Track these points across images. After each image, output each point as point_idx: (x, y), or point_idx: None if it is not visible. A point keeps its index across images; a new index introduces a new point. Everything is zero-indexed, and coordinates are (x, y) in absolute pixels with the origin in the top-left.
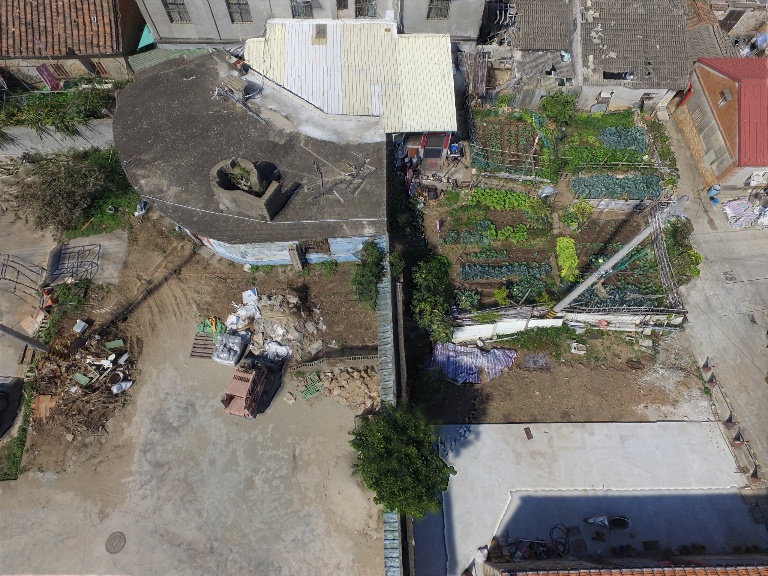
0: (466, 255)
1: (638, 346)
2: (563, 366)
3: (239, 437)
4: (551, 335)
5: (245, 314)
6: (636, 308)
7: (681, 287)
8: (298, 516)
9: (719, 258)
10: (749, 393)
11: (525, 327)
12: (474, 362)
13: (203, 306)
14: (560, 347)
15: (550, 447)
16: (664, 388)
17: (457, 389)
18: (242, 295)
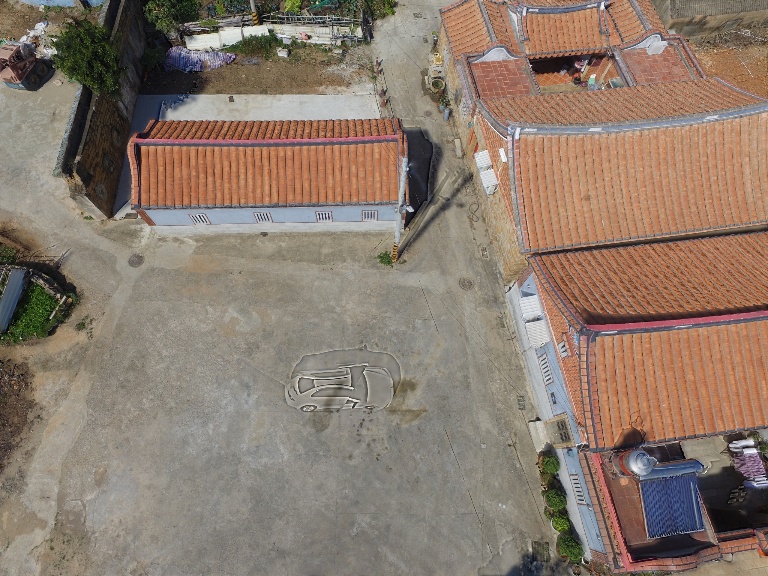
0: (215, 1)
1: (331, 53)
2: (268, 62)
3: (15, 104)
4: (261, 41)
5: (33, 34)
6: (322, 18)
7: (377, 21)
8: (49, 145)
9: (414, 5)
10: (405, 79)
11: (242, 35)
12: (199, 57)
13: (3, 32)
14: (270, 52)
15: (245, 107)
16: (341, 74)
17: (185, 75)
18: (35, 25)
